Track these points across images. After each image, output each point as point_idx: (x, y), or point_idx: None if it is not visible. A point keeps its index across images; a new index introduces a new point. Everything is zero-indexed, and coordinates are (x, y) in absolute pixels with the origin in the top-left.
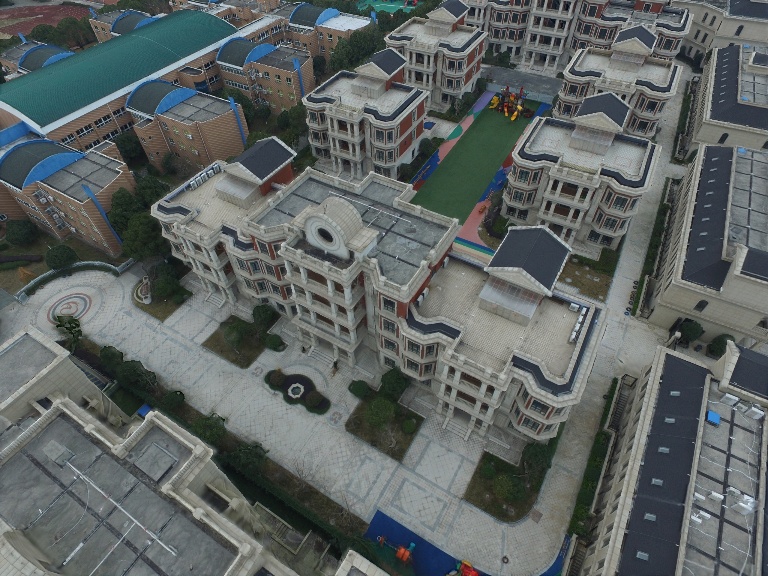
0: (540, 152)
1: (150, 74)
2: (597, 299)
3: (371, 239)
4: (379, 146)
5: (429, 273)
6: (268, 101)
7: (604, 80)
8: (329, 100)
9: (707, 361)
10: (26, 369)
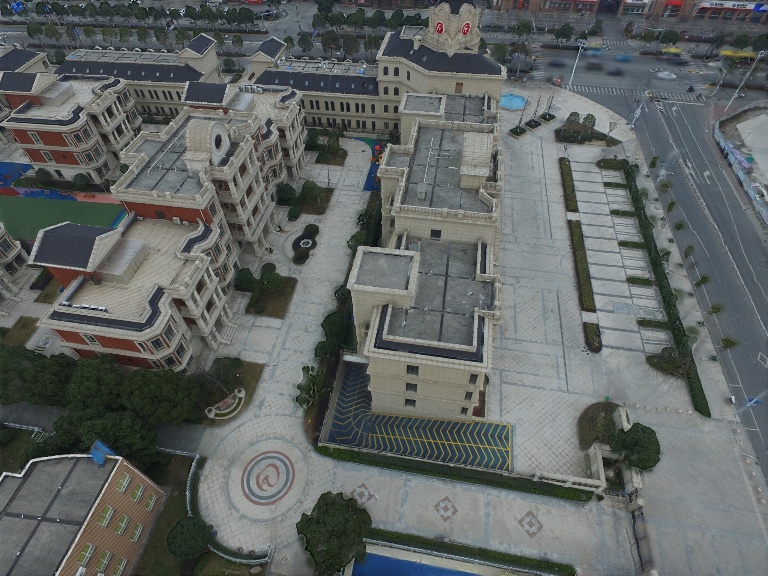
0: (71, 112)
1: None
2: None
3: None
4: None
5: None
6: None
7: None
8: None
9: None
10: (382, 265)
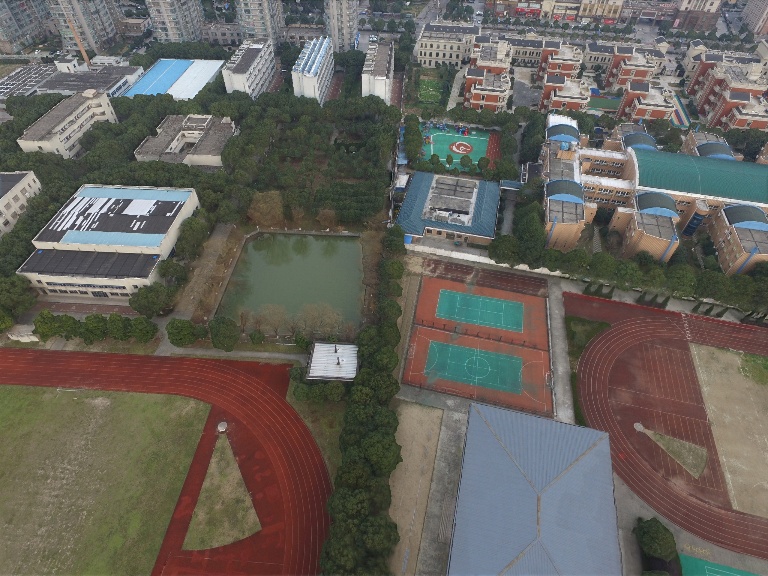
0: None
1: None
2: None
3: None
4: None
5: None
6: None
7: None
8: None
9: None
10: None
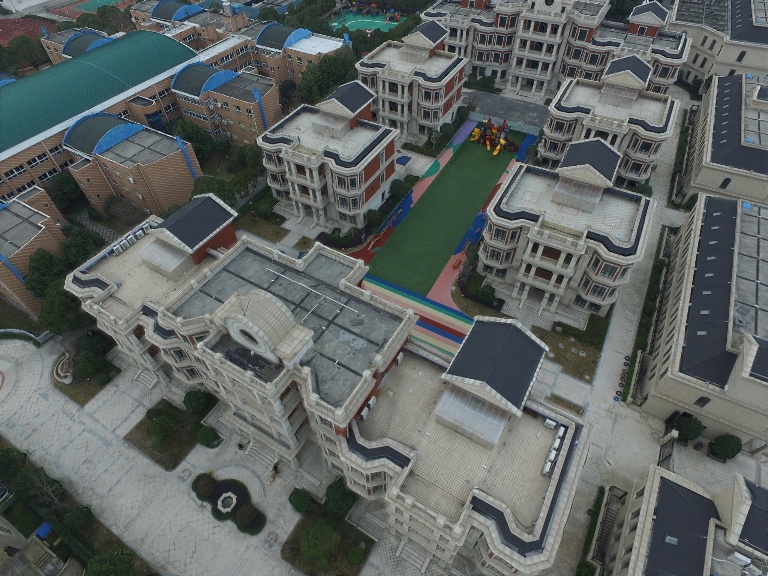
0: (518, 210)
1: (93, 106)
2: (583, 380)
3: (303, 343)
4: (341, 193)
5: (374, 384)
6: (229, 132)
7: (593, 118)
8: (286, 140)
9: (709, 463)
10: None
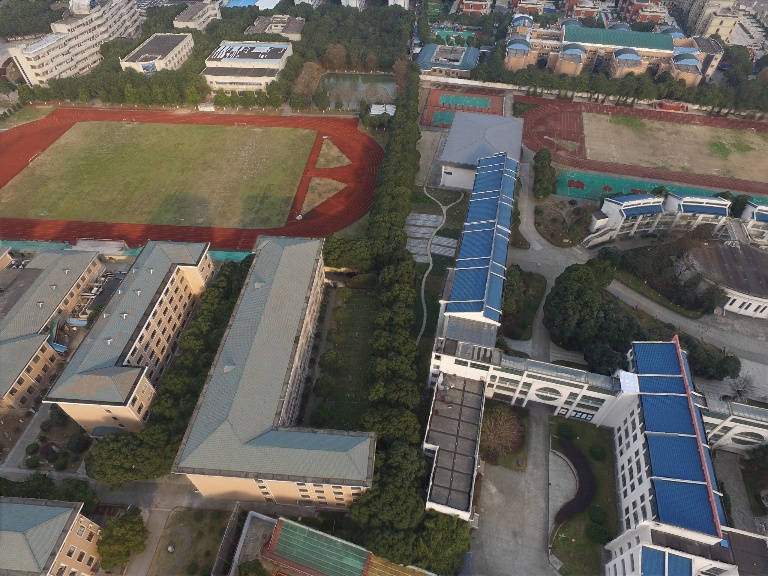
0: None
1: None
2: None
3: None
4: None
5: None
6: None
7: None
8: None
9: None
10: None
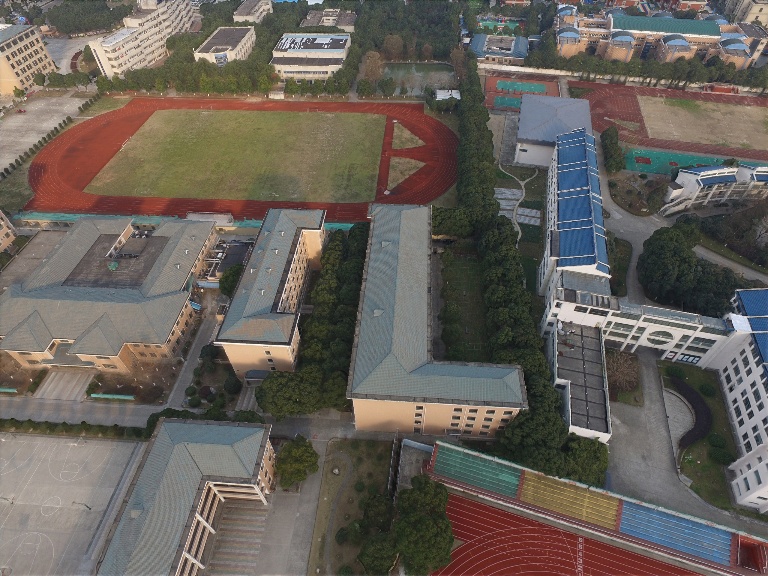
0: None
1: None
2: None
3: None
4: None
5: None
6: None
7: None
8: None
9: None
10: None
